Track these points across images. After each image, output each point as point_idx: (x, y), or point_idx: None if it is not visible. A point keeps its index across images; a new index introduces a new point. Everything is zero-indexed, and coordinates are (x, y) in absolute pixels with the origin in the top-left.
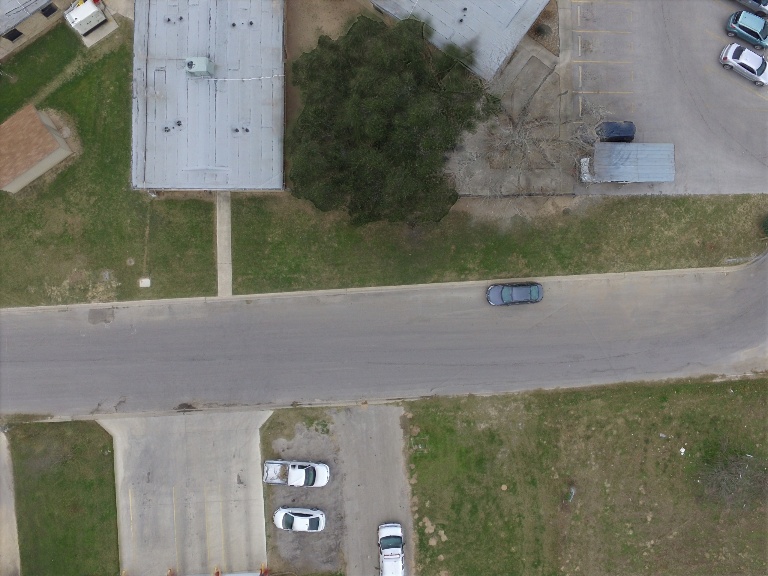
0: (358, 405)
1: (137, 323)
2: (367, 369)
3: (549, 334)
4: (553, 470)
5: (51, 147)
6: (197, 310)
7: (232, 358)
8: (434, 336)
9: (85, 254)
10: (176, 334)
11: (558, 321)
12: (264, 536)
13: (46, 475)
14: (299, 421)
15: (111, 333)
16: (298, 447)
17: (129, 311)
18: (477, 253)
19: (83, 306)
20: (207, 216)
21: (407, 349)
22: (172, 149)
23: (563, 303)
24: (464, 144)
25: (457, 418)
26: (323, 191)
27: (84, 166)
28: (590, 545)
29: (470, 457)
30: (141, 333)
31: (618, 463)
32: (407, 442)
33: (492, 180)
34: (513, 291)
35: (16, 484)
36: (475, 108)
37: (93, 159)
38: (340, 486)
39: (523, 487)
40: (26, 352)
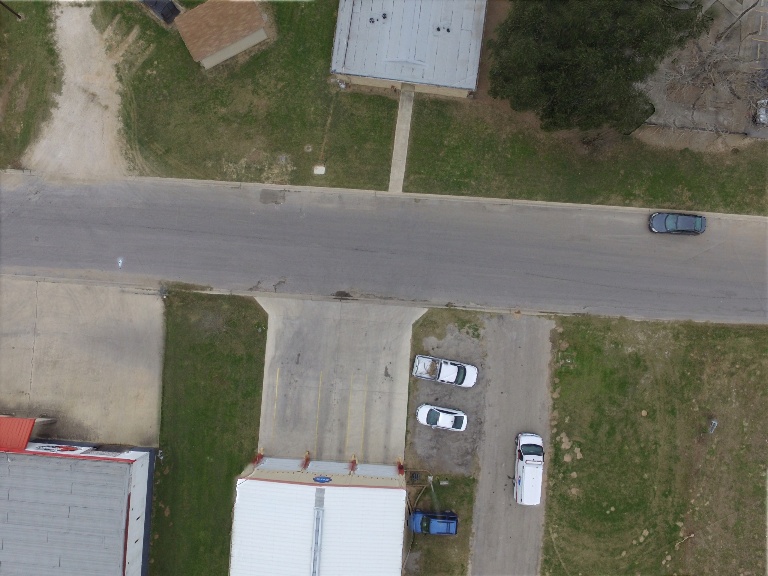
0: (511, 313)
1: (307, 208)
2: (524, 279)
3: (704, 268)
4: (694, 402)
5: (257, 25)
6: (366, 202)
7: (395, 252)
8: (593, 256)
9: (265, 135)
10: (343, 223)
11: (714, 257)
12: (404, 430)
13: (198, 344)
14: (452, 322)
15: (280, 214)
16: (448, 347)
17: (300, 195)
18: (644, 180)
19: (256, 185)
20: (389, 113)
21: (565, 265)
22: (373, 40)
23: (721, 240)
24: (671, 58)
25: (606, 338)
26: (532, 86)
27: (276, 52)
28: (722, 481)
29: (614, 379)
30: (309, 218)
31: (758, 404)
32: (554, 356)
33: (667, 112)
34: (678, 219)
35: (167, 350)
36: (692, 22)
37: (286, 46)
38: (484, 391)
39: (663, 415)
40: (195, 223)
